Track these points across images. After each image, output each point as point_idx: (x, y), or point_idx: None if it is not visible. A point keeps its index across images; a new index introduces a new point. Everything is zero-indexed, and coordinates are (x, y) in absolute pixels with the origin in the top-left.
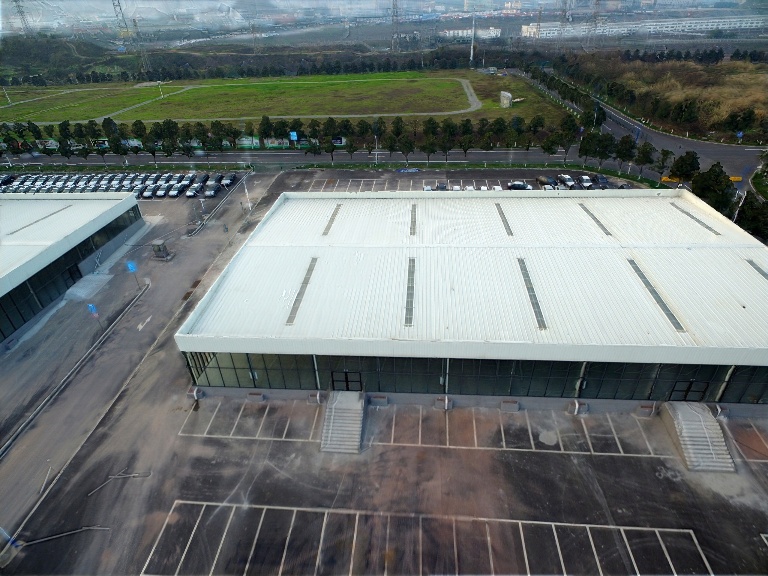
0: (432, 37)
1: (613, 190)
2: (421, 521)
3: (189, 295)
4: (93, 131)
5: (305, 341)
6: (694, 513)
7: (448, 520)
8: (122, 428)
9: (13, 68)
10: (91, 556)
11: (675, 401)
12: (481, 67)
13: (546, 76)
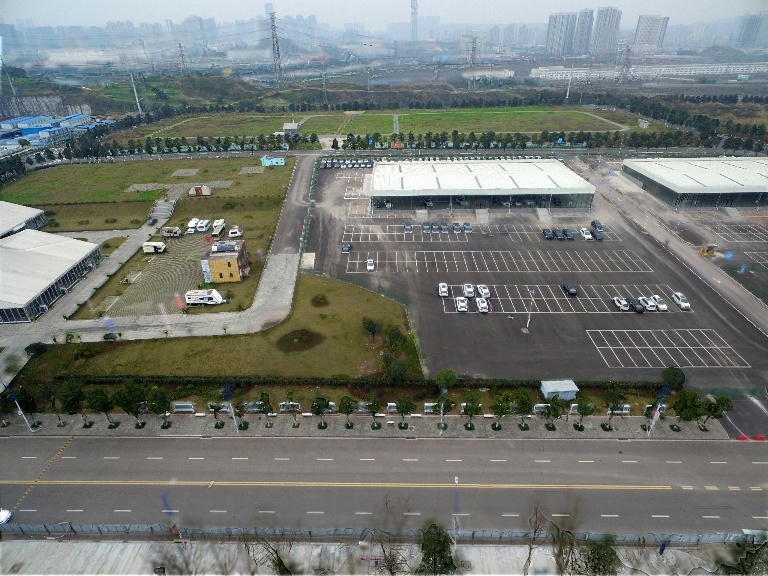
0: (501, 80)
1: (764, 157)
2: None
3: None
4: (445, 137)
5: (721, 188)
6: None
7: None
8: None
9: (205, 99)
10: None
11: None
12: (579, 104)
13: (649, 111)
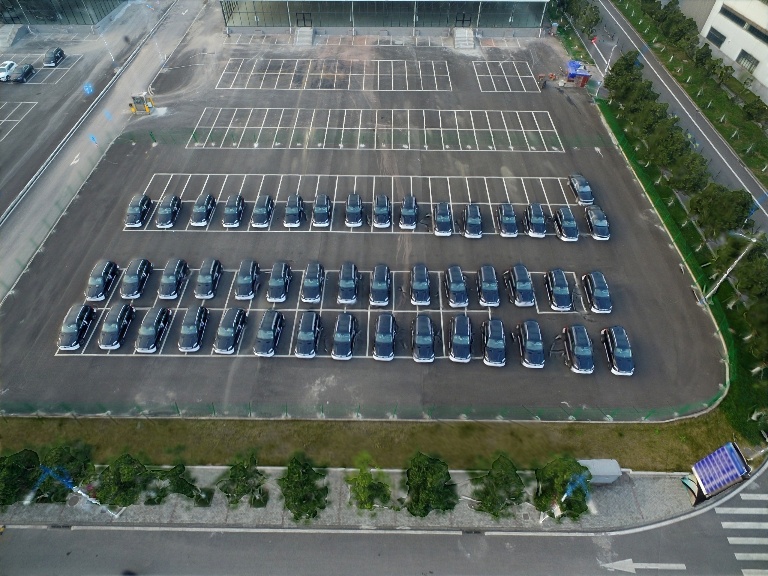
0: None
1: None
2: (338, 61)
3: (207, 1)
4: None
5: None
6: (450, 57)
7: (349, 60)
8: (194, 42)
9: None
10: (200, 70)
11: (459, 27)
12: None
13: None
